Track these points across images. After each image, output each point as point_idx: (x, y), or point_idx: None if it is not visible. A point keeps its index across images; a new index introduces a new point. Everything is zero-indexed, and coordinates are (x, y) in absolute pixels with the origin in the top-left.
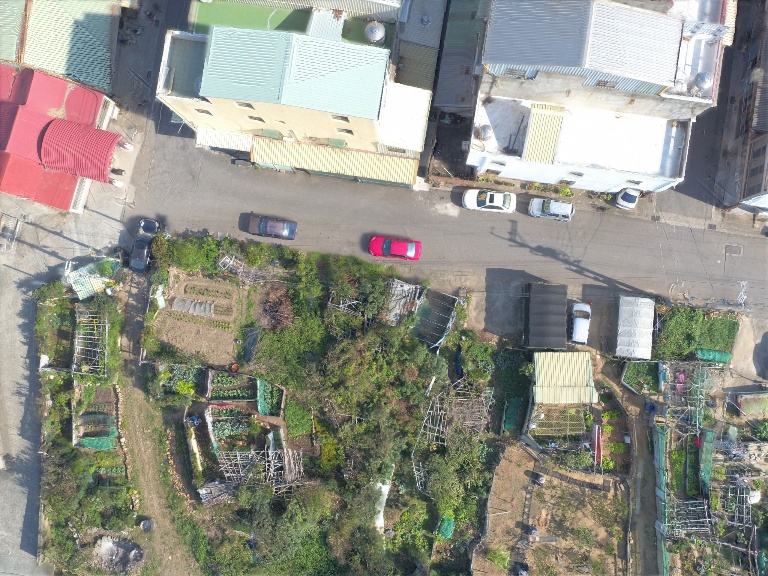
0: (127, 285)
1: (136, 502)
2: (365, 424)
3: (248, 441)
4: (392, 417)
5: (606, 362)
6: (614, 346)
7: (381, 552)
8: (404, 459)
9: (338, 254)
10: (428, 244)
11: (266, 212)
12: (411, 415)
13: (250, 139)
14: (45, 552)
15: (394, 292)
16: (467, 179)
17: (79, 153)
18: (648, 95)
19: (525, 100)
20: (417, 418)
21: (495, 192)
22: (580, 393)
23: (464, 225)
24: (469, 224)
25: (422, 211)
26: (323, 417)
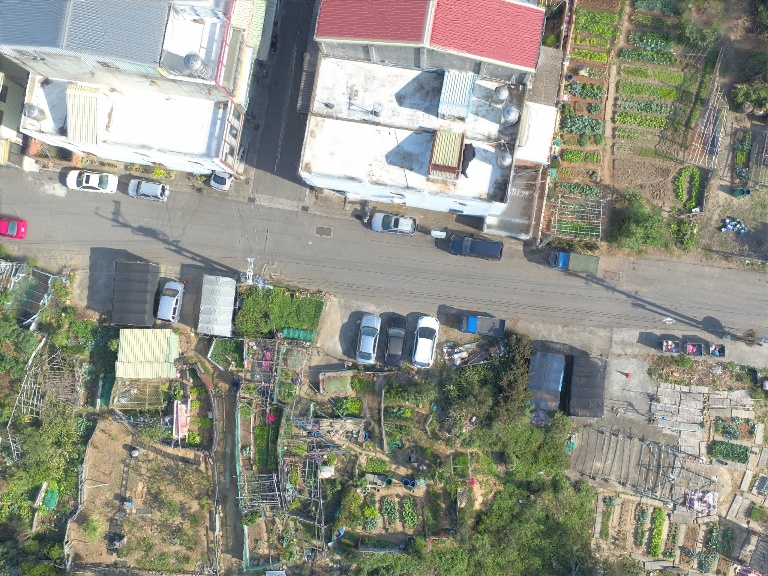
0: None
1: None
2: None
3: None
4: None
5: (199, 339)
6: None
7: None
8: None
9: None
10: (36, 223)
11: None
12: (12, 389)
13: None
14: None
15: None
16: None
17: None
18: (156, 76)
19: (79, 82)
20: (18, 392)
21: (93, 173)
22: (158, 368)
23: (70, 205)
24: (75, 204)
25: (31, 191)
26: None
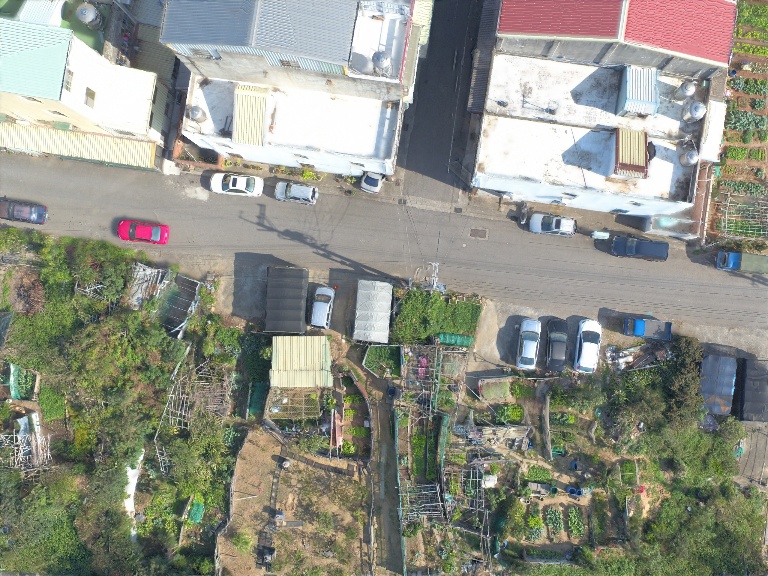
0: None
1: None
2: (111, 408)
3: (4, 426)
4: (139, 401)
5: (351, 346)
6: (353, 330)
7: (124, 536)
8: (150, 443)
9: (89, 238)
10: (178, 228)
11: (19, 196)
12: (157, 399)
13: None
14: None
15: (136, 276)
16: None
17: None
18: (336, 75)
19: (241, 82)
20: (163, 402)
21: (239, 176)
22: (315, 377)
23: (213, 209)
24: (218, 208)
25: (172, 195)
26: (76, 402)
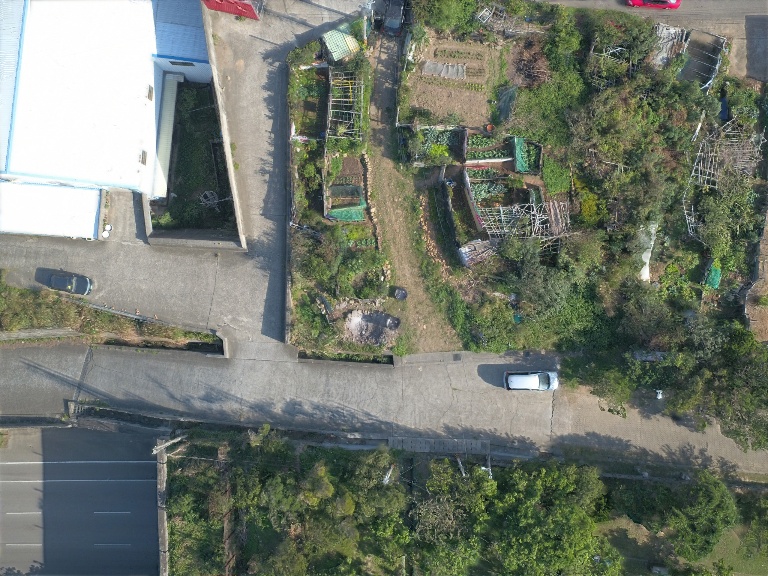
0: (376, 50)
1: (387, 273)
2: (631, 173)
3: (504, 203)
4: (658, 165)
5: None
6: None
7: (655, 297)
8: (673, 206)
9: (594, 8)
10: None
11: None
12: (678, 162)
13: None
14: (295, 328)
15: (660, 35)
16: None
17: None
18: None
19: None
20: (684, 165)
21: None
22: None
23: None
24: None
25: None
26: (582, 173)
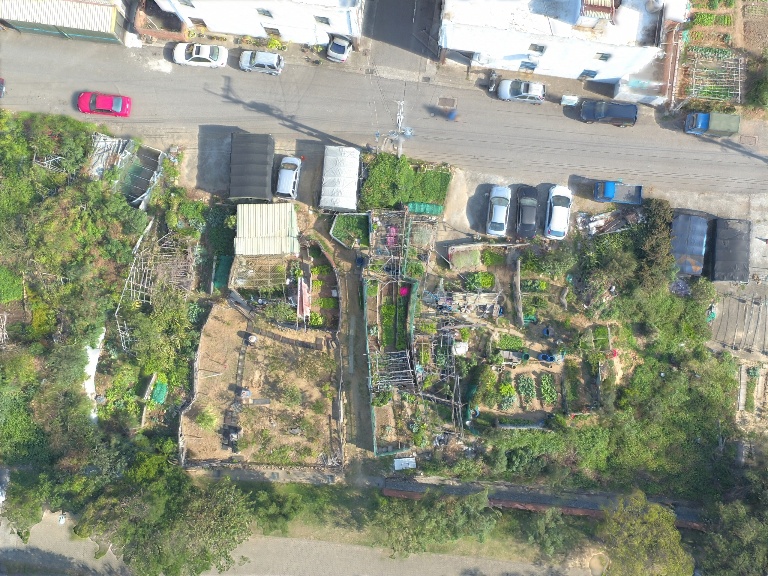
0: None
1: None
2: (71, 284)
3: None
4: (99, 277)
5: (318, 217)
6: None
7: (84, 415)
8: (111, 319)
9: (48, 113)
10: (140, 101)
11: None
12: (118, 274)
13: None
14: None
15: (96, 146)
16: None
17: None
18: None
19: None
20: (124, 277)
21: None
22: (281, 243)
23: (176, 81)
24: (181, 80)
25: (134, 68)
26: (34, 281)
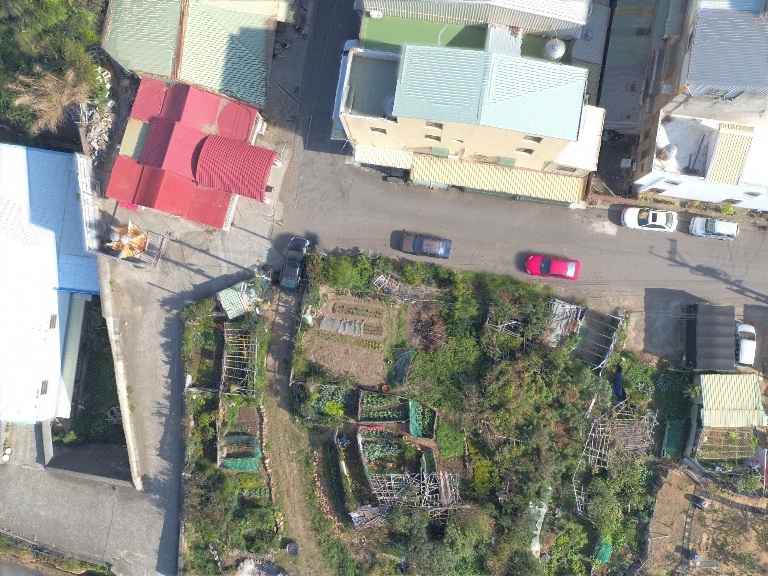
0: (274, 304)
1: (280, 524)
2: (523, 447)
3: (398, 463)
4: (550, 439)
5: None
6: None
7: None
8: (563, 482)
9: (493, 273)
10: (585, 263)
11: (418, 230)
12: (570, 437)
13: (410, 156)
14: (186, 575)
15: (555, 312)
16: (625, 197)
17: (236, 170)
18: None
19: (706, 119)
20: (576, 440)
21: (657, 211)
22: (749, 416)
23: (622, 244)
24: (627, 243)
25: (579, 229)
26: (476, 439)
